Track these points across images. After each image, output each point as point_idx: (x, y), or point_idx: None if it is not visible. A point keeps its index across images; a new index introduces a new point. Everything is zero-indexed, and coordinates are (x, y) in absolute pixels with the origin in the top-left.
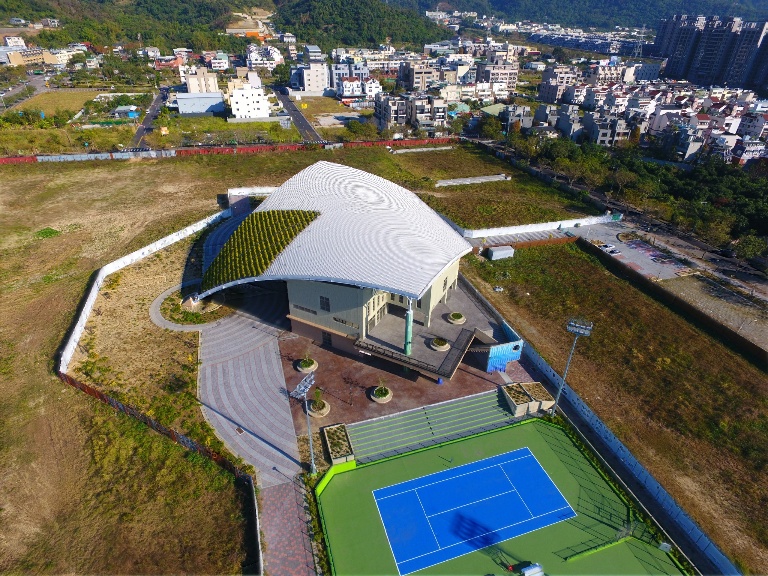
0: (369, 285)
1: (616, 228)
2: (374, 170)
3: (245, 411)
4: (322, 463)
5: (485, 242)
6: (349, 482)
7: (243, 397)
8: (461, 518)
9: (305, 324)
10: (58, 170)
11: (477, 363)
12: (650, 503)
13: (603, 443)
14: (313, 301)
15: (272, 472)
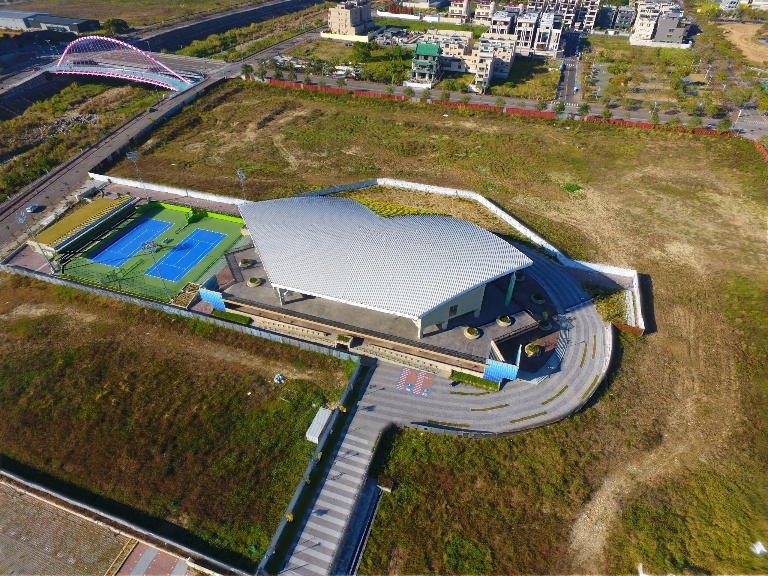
0: None
1: None
2: None
3: None
4: None
5: None
6: None
7: None
8: (189, 247)
9: None
10: (758, 197)
11: None
12: None
13: None
14: None
15: None
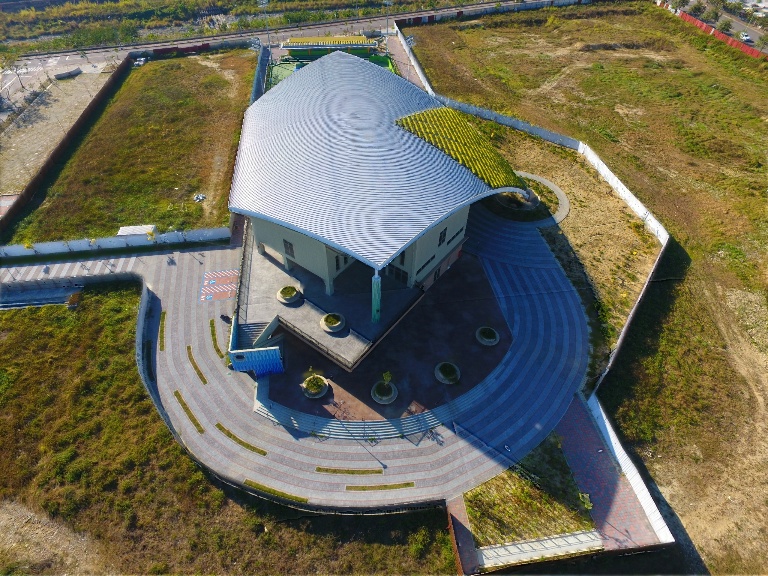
0: None
1: None
2: None
3: None
4: None
5: None
6: None
7: None
8: None
9: None
10: None
11: None
12: None
13: None
14: None
15: None
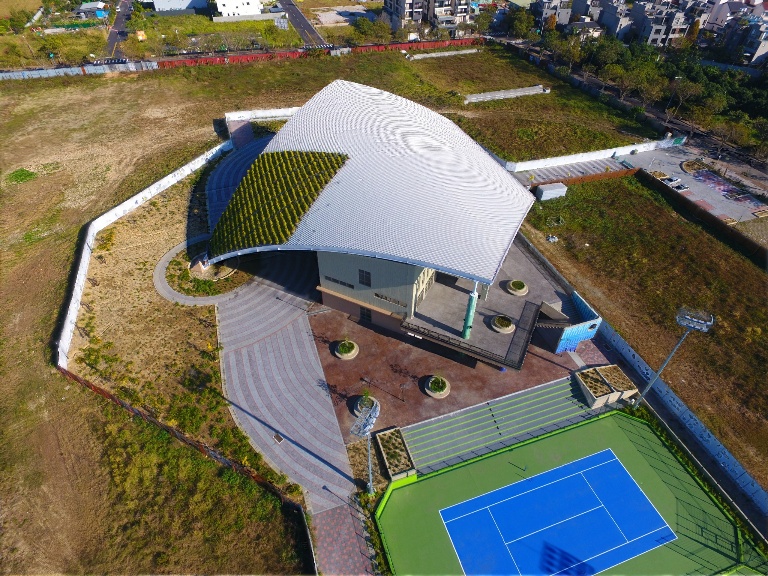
0: (426, 264)
1: (678, 155)
2: (391, 83)
3: (281, 412)
4: (379, 479)
5: (532, 178)
6: (411, 499)
7: (277, 393)
8: (545, 544)
9: (340, 298)
10: (23, 90)
11: (543, 342)
12: (760, 521)
13: (698, 443)
14: (350, 274)
15: (322, 492)
